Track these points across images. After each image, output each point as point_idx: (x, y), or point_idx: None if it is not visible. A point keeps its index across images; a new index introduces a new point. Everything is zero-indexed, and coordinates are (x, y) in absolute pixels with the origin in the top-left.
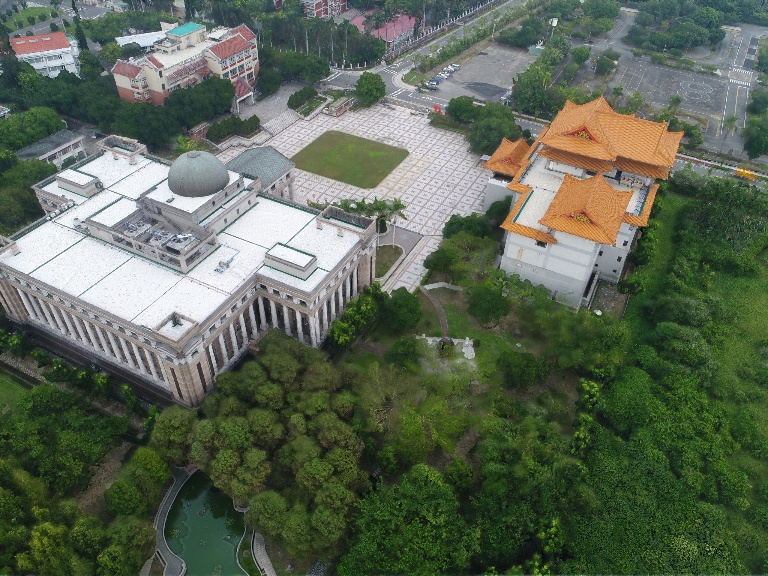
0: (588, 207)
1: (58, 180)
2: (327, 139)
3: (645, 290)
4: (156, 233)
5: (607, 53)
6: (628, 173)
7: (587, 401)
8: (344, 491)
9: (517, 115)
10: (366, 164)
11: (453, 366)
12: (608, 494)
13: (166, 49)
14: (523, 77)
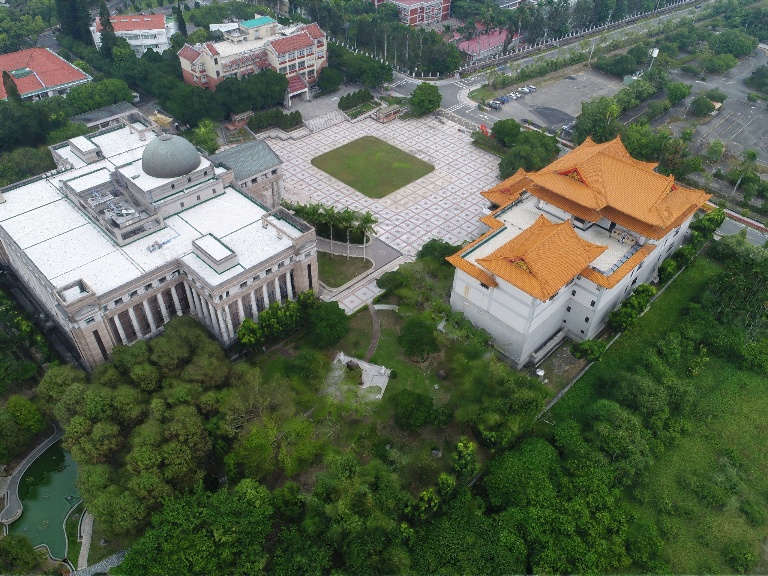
0: (531, 255)
1: (69, 144)
2: (361, 143)
3: (617, 360)
4: (111, 205)
5: (711, 93)
6: (622, 227)
7: (456, 462)
8: (154, 484)
9: (573, 147)
10: (385, 174)
11: (340, 391)
12: (431, 567)
13: (233, 39)
14: (585, 107)
